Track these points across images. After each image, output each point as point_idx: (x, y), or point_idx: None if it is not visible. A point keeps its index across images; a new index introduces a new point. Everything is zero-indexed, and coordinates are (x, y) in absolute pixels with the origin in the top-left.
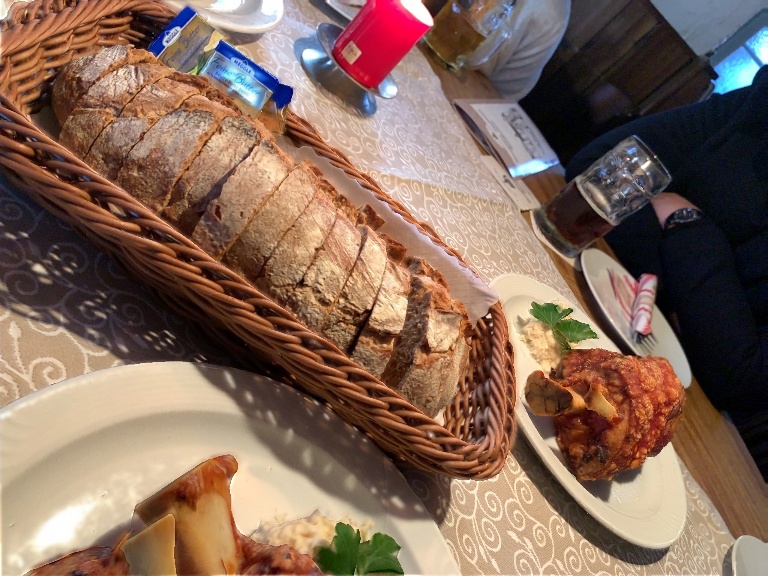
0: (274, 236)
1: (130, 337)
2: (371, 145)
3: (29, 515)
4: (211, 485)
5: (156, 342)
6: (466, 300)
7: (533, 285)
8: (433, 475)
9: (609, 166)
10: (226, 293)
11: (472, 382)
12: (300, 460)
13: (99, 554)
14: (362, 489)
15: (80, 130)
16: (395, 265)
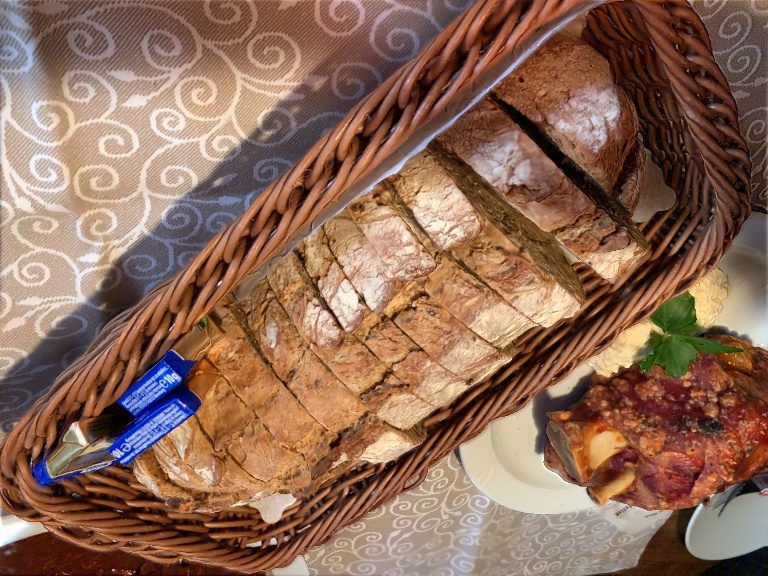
0: None
1: None
2: None
3: (512, 449)
4: (587, 459)
5: None
6: None
7: None
8: None
9: None
10: None
11: None
12: None
13: None
14: None
15: None
16: (513, 292)
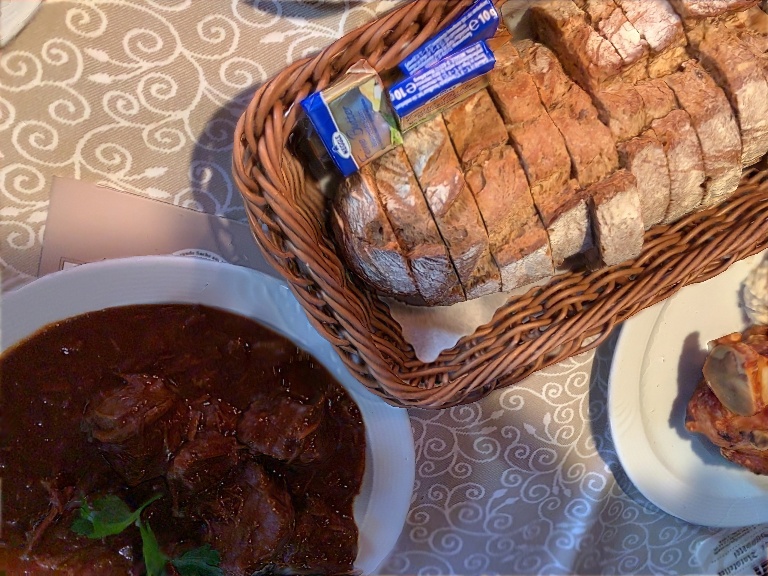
0: None
1: None
2: None
3: (652, 402)
4: (759, 385)
5: None
6: None
7: None
8: None
9: None
10: None
11: None
12: None
13: (707, 403)
14: None
15: None
16: None
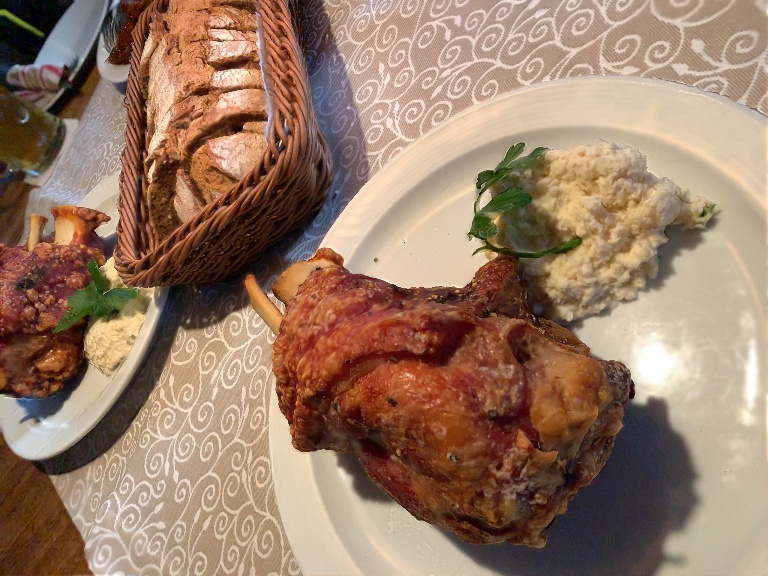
0: None
1: None
2: None
3: (107, 214)
4: (65, 215)
5: None
6: None
7: (645, 101)
8: (225, 296)
9: None
10: None
11: None
12: None
13: None
14: None
15: None
16: (174, 106)
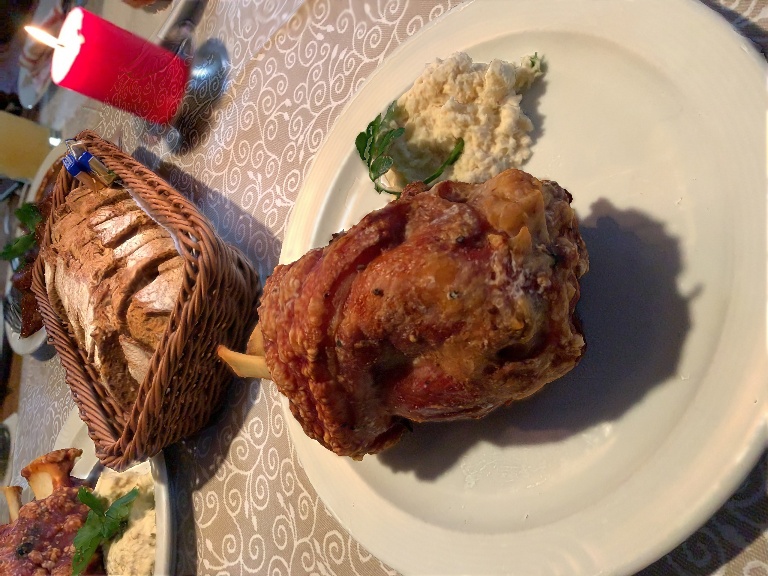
0: None
1: None
2: None
3: None
4: (36, 469)
5: None
6: None
7: (444, 32)
8: (219, 433)
9: None
10: None
11: None
12: None
13: None
14: None
15: None
16: None
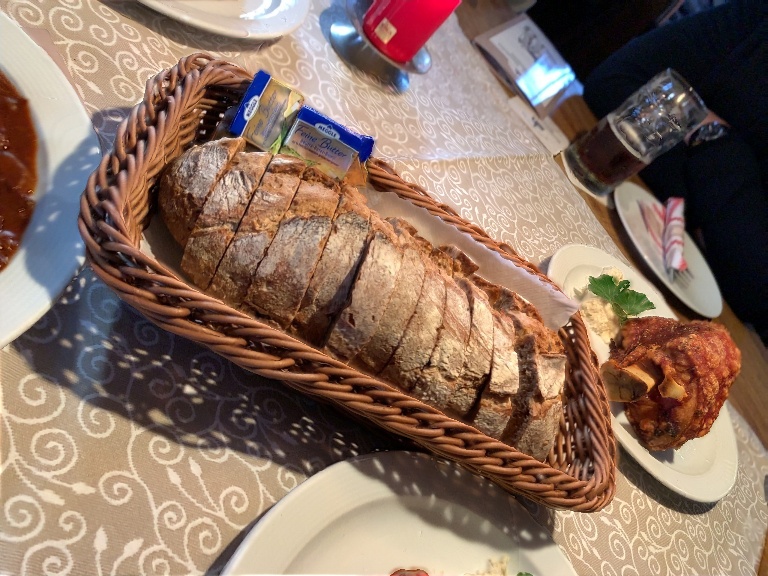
0: (400, 326)
1: (280, 437)
2: (413, 127)
3: None
4: None
5: (301, 434)
6: (546, 311)
7: (584, 252)
8: None
9: (643, 103)
10: (375, 402)
11: (563, 396)
12: (442, 518)
13: None
14: (496, 531)
15: (204, 253)
16: (500, 318)
